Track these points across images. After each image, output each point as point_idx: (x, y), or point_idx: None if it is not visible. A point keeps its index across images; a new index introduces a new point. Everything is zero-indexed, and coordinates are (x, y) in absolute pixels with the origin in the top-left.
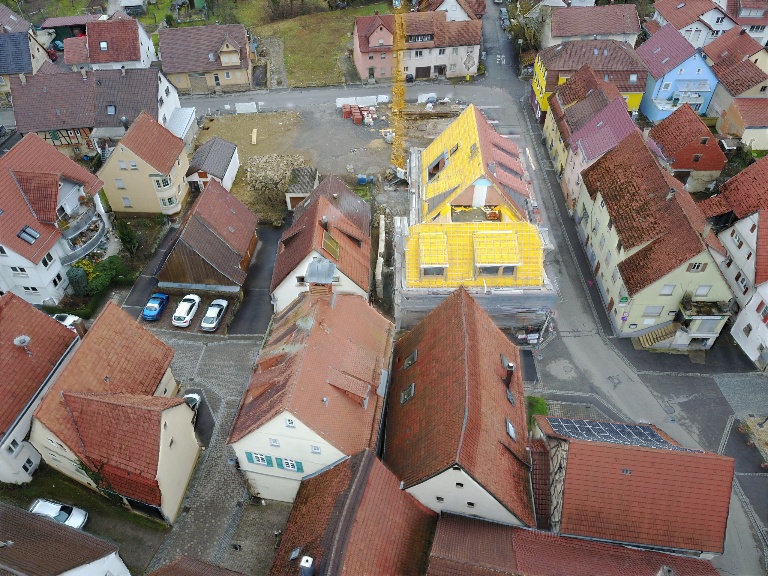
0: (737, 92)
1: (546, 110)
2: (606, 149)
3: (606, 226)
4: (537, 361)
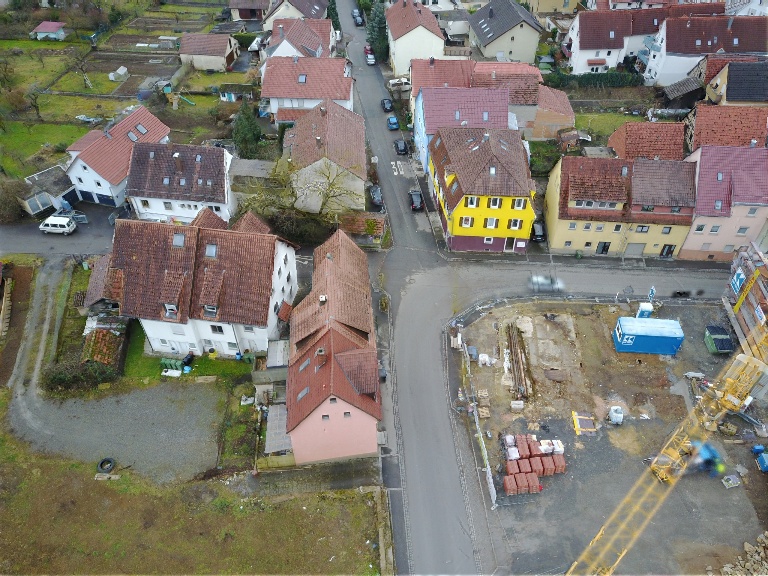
0: (535, 100)
1: None
2: None
3: None
4: None
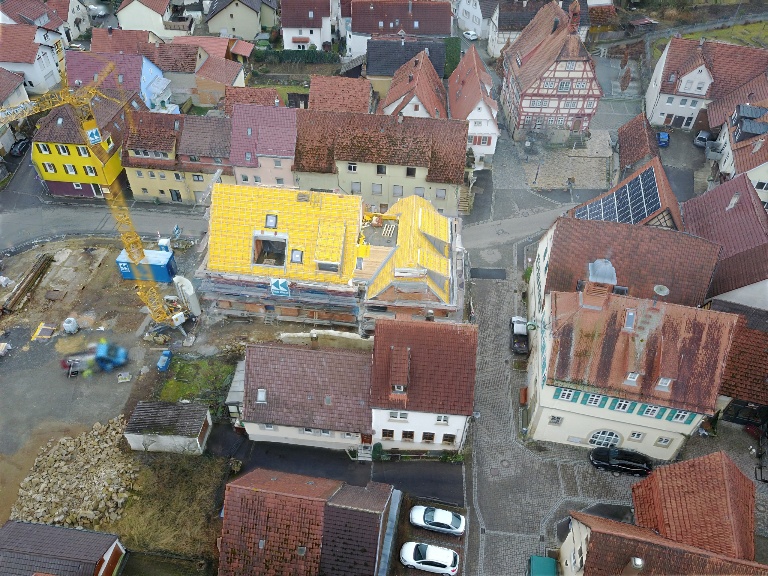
0: (191, 69)
1: (112, 182)
2: (294, 138)
3: (376, 175)
4: (483, 267)
